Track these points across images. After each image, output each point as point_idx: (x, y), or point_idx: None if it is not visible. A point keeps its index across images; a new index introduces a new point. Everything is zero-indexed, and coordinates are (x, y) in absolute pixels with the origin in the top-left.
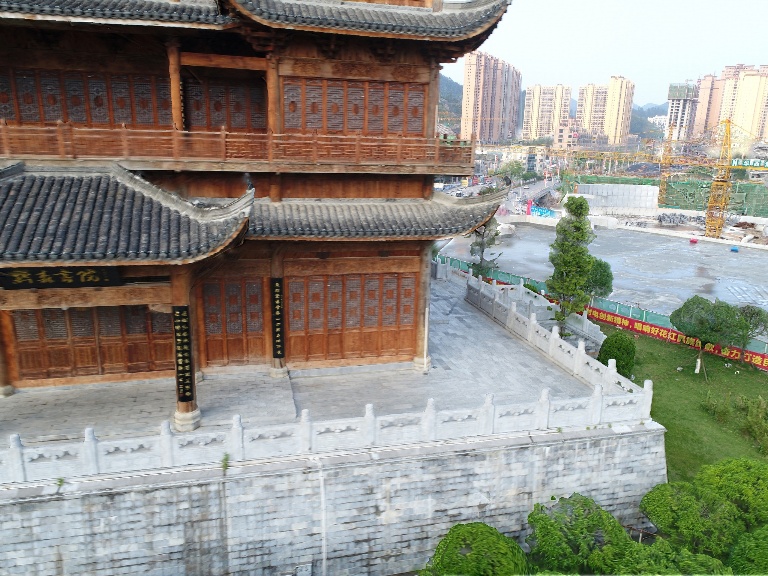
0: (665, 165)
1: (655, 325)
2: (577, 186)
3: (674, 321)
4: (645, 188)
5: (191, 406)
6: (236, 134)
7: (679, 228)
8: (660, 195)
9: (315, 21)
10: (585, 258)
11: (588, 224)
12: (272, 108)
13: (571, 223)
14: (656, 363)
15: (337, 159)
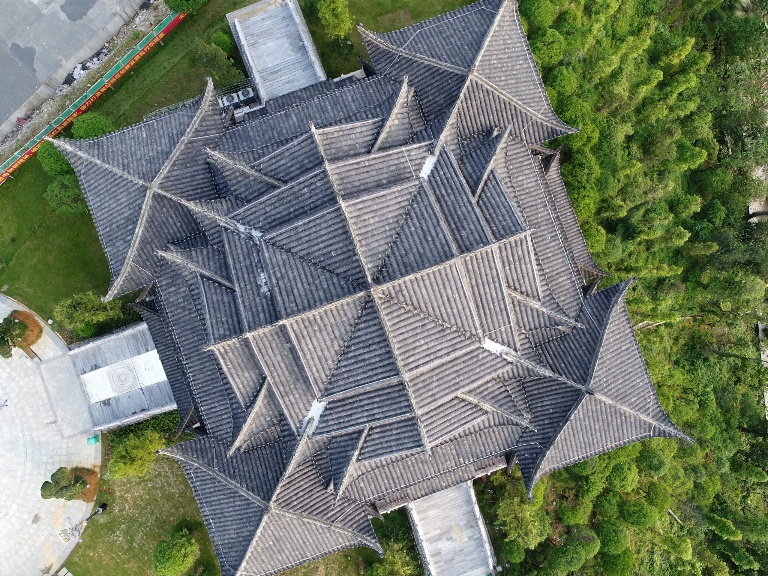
0: None
1: None
2: None
3: None
4: None
5: None
6: None
7: None
8: None
9: None
10: (347, 3)
11: None
12: None
13: (329, 0)
14: None
15: None
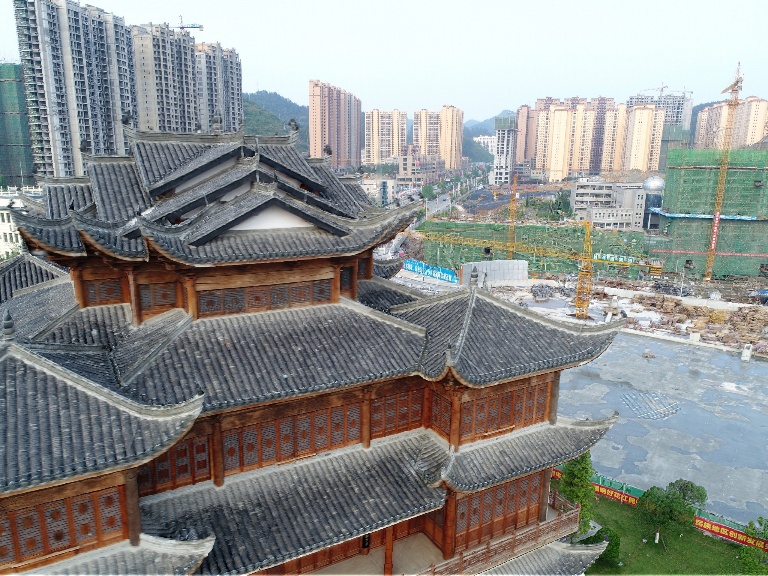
0: (539, 255)
1: (610, 488)
2: (462, 266)
3: (642, 511)
4: (516, 263)
5: None
6: (441, 565)
7: (552, 305)
8: (529, 268)
9: (499, 480)
10: (592, 492)
11: (590, 463)
12: (451, 524)
13: (577, 461)
14: (625, 535)
15: (500, 554)
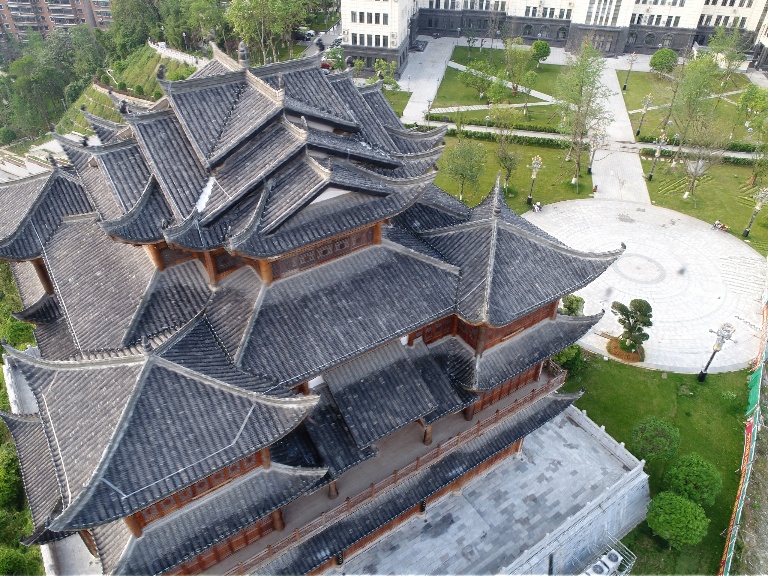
0: None
1: None
2: None
3: None
4: None
5: (94, 556)
6: None
7: None
8: None
9: None
10: None
11: None
12: None
13: None
14: None
15: None
